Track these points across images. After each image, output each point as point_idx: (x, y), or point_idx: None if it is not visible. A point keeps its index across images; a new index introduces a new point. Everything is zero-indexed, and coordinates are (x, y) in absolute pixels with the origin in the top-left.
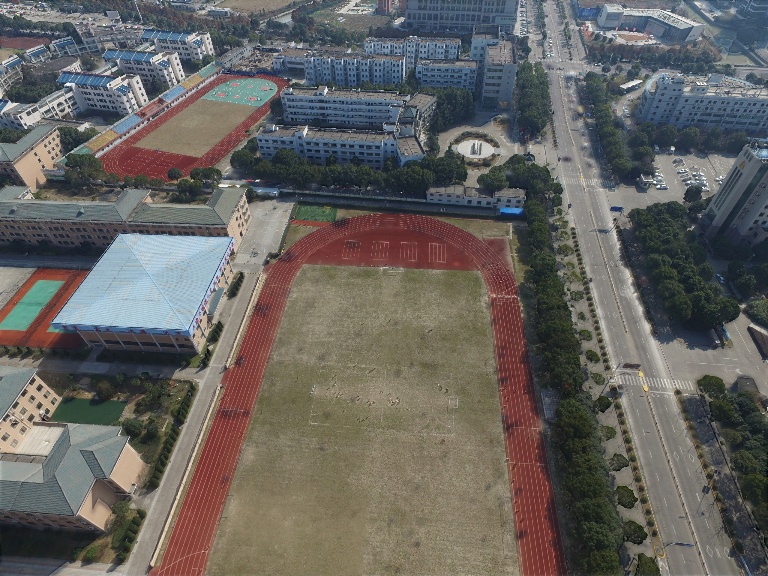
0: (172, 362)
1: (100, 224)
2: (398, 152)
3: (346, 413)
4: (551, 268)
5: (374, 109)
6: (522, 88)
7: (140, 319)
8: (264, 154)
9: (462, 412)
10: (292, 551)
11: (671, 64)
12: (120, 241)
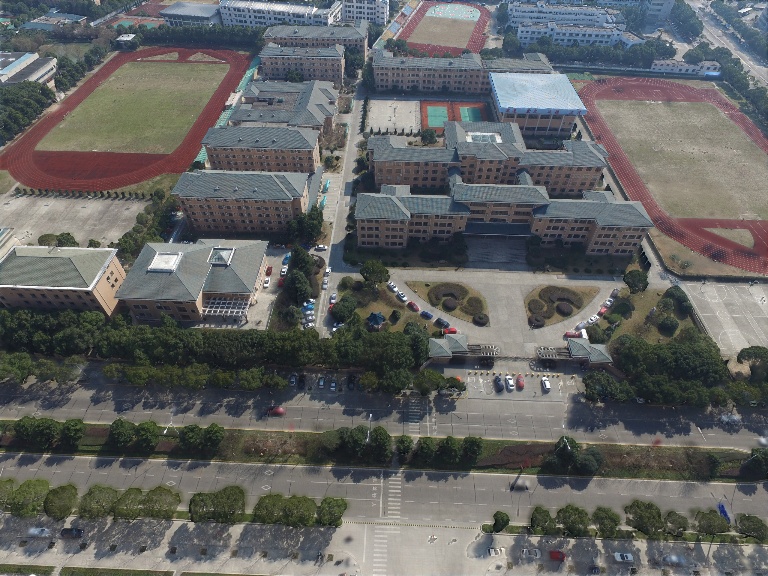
0: (559, 138)
1: (463, 71)
2: (623, 39)
3: (681, 156)
4: (765, 94)
5: (579, 19)
6: (677, 8)
7: (553, 105)
8: (520, 43)
9: (746, 155)
10: (697, 199)
11: (763, 0)
12: (496, 75)
